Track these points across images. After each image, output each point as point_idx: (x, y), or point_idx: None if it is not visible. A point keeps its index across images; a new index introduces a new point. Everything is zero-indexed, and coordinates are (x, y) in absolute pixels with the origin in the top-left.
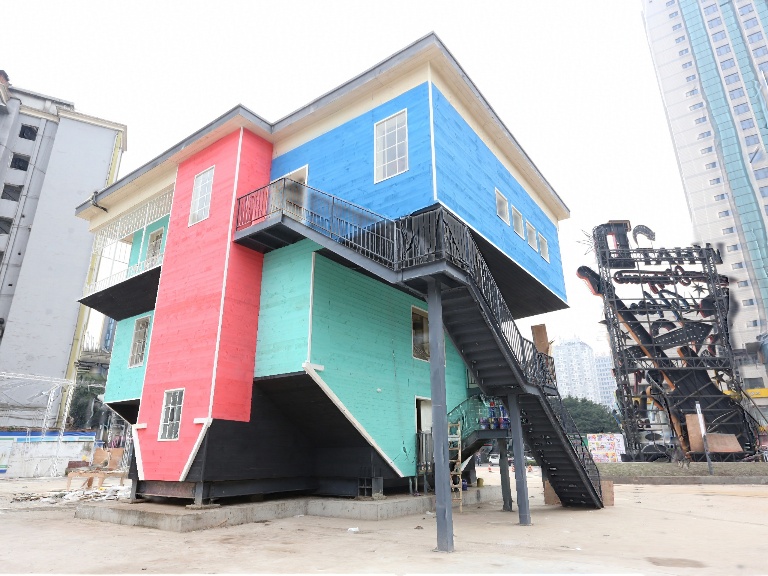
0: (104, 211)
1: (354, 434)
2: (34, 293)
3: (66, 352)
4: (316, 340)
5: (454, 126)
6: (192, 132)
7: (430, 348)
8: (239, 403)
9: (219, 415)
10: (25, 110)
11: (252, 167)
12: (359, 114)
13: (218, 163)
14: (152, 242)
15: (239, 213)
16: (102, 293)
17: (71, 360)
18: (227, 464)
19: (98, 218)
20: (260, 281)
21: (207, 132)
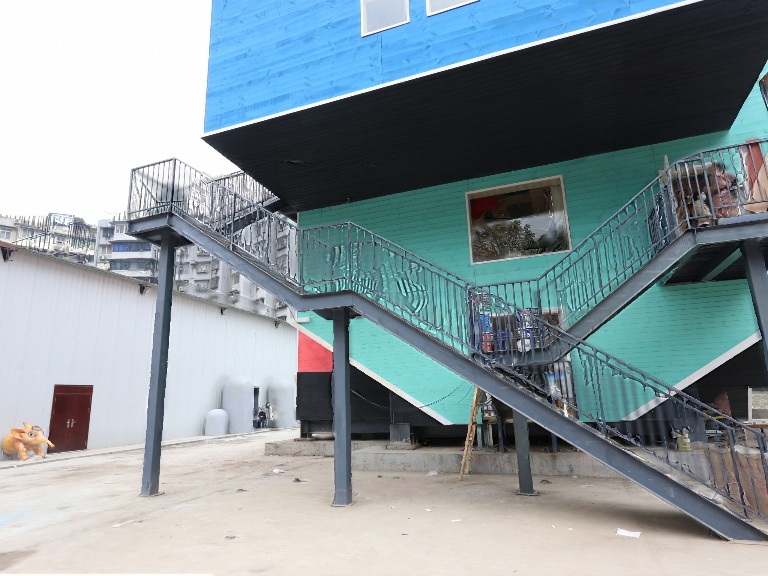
0: None
1: None
2: None
3: None
4: None
5: (256, 7)
6: None
7: None
8: (321, 357)
9: (305, 369)
10: None
11: None
12: None
13: None
14: None
15: None
16: None
17: None
18: (316, 407)
19: None
20: None
21: None
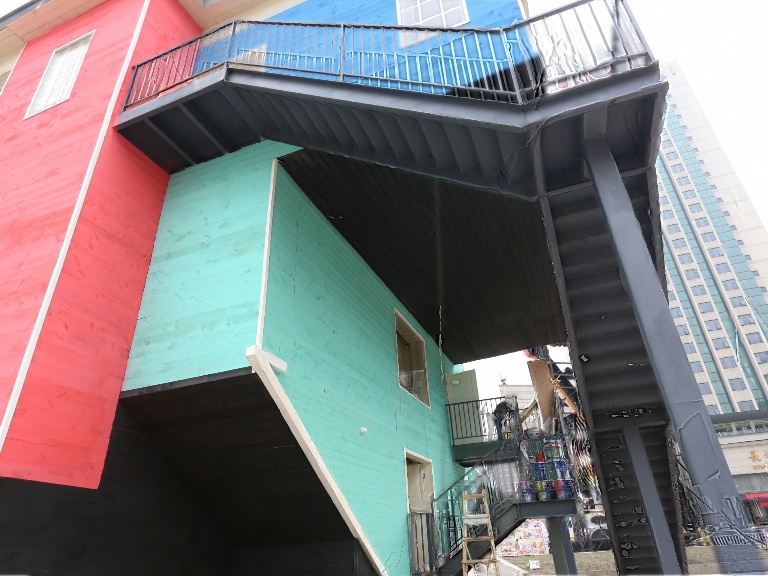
0: None
1: (324, 514)
2: None
3: None
4: (273, 310)
5: None
6: None
7: (627, 265)
8: (78, 443)
9: (19, 468)
10: None
11: (165, 39)
12: None
13: (102, 26)
14: None
15: (133, 87)
16: None
17: None
18: None
19: None
20: (158, 215)
21: None
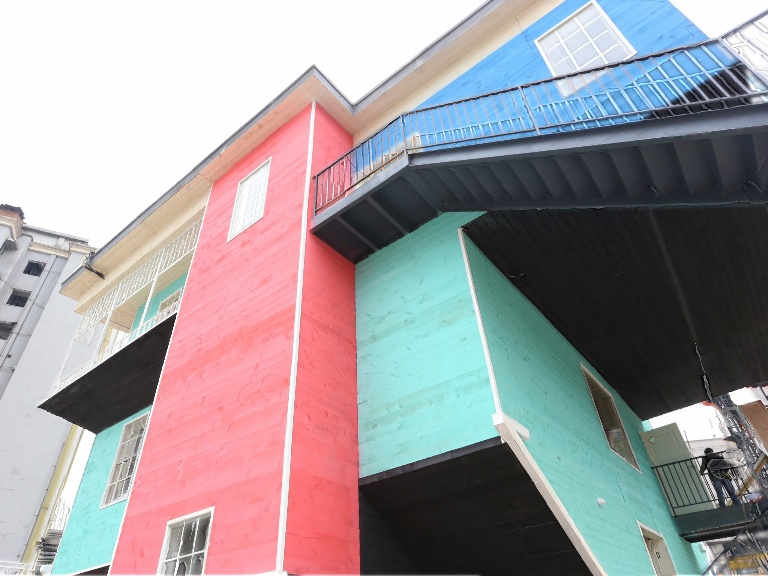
0: (100, 279)
1: None
2: (2, 447)
3: (27, 527)
4: (499, 375)
5: None
6: None
7: None
8: (337, 535)
9: (299, 564)
10: (35, 247)
11: (329, 150)
12: (500, 45)
13: (277, 152)
14: None
15: (318, 193)
16: (77, 385)
17: (32, 538)
18: None
19: (90, 291)
20: (353, 303)
21: (261, 116)
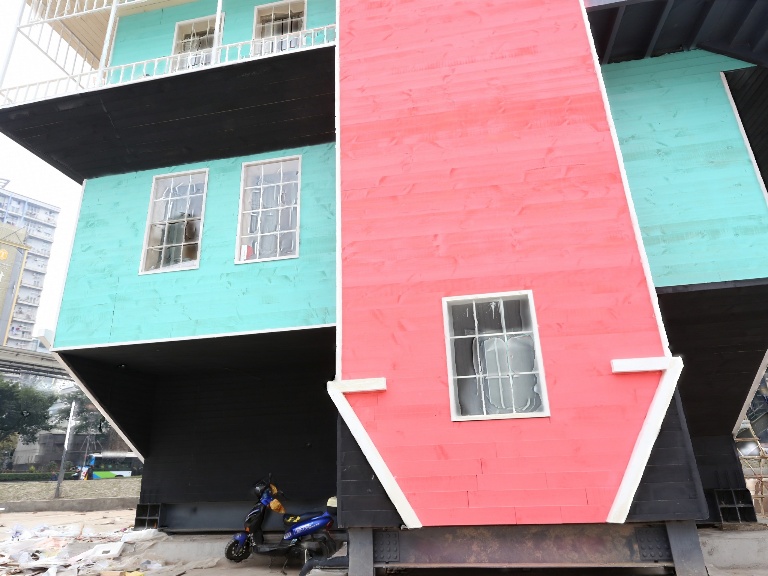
0: None
1: (725, 412)
2: None
3: None
4: None
5: None
6: None
7: None
8: None
9: None
10: None
11: None
12: None
13: None
14: (185, 39)
15: None
16: (78, 101)
17: None
18: None
19: None
20: None
21: None
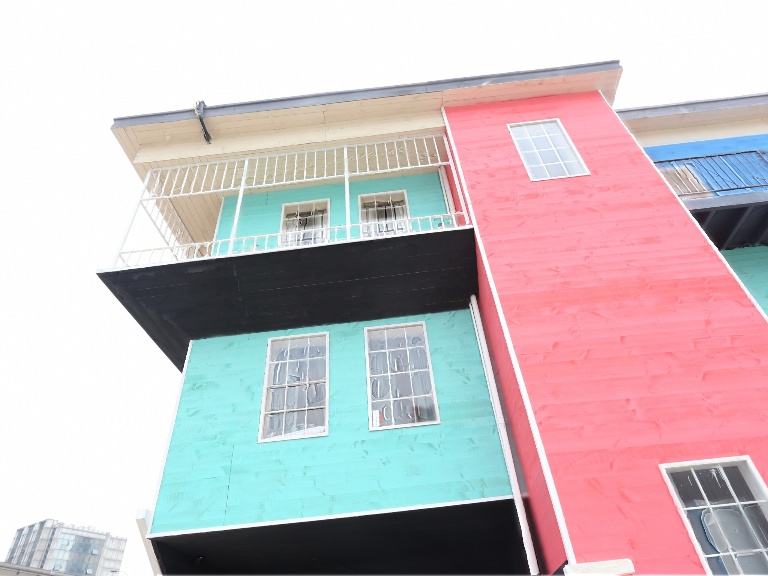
0: (196, 140)
1: None
2: None
3: None
4: None
5: None
6: (509, 70)
7: None
8: None
9: None
10: None
11: None
12: (756, 133)
13: (566, 117)
14: None
15: None
16: (210, 265)
17: None
18: None
19: (173, 148)
20: None
21: (549, 75)
